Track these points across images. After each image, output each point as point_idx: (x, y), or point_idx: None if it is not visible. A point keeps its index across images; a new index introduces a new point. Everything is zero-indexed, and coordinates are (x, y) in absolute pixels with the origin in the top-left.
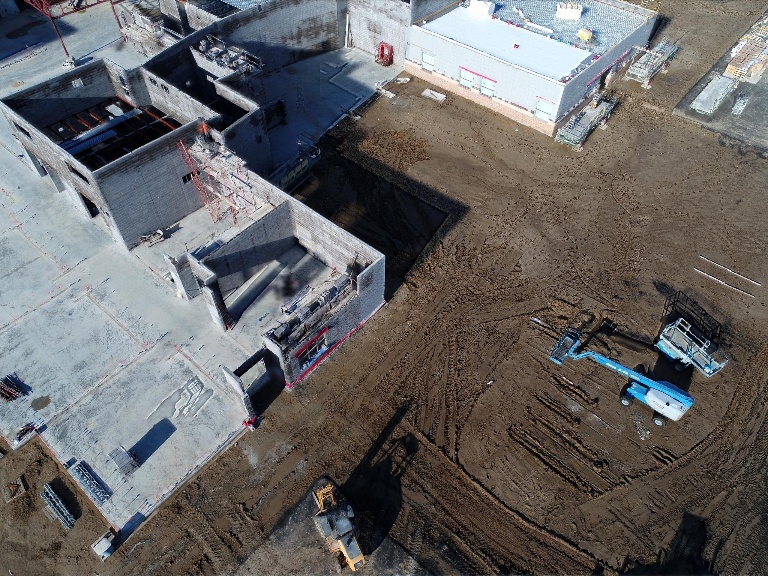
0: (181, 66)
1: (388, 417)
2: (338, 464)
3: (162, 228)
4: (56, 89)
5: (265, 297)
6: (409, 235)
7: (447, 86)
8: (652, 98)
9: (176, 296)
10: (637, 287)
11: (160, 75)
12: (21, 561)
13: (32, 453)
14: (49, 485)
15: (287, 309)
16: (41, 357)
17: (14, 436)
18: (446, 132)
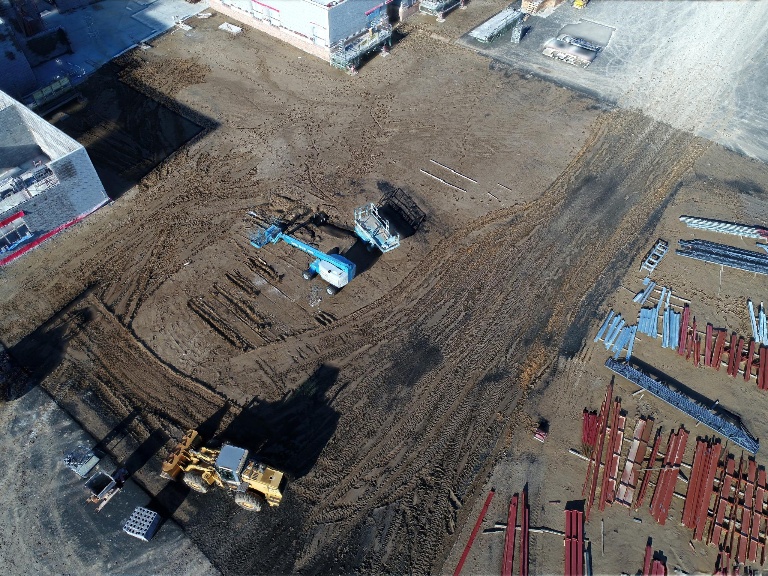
0: None
1: (78, 293)
2: (14, 331)
3: None
4: None
5: None
6: (159, 145)
7: (245, 20)
8: (442, 30)
9: None
10: (361, 186)
11: None
12: None
13: None
14: None
15: None
16: None
17: None
18: (230, 59)
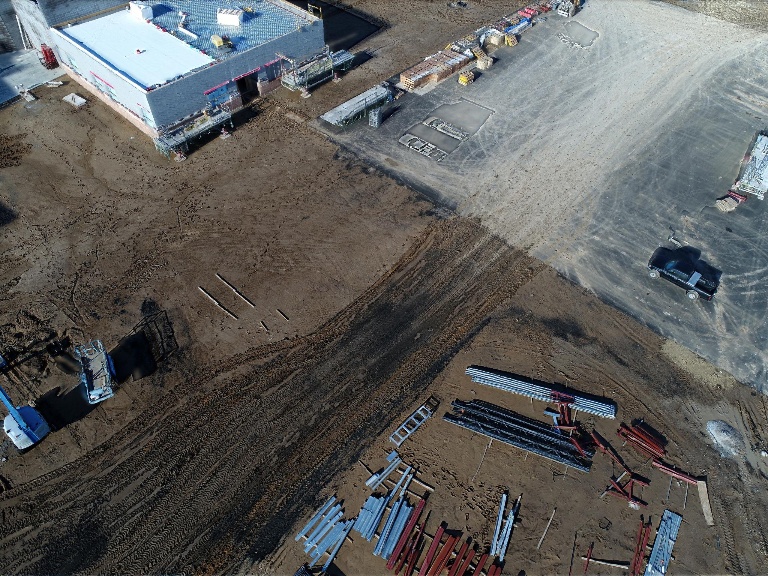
0: None
1: None
2: None
3: None
4: None
5: None
6: None
7: (93, 91)
8: (301, 108)
9: None
10: (123, 305)
11: None
12: None
13: None
14: None
15: None
16: None
17: None
18: (58, 138)
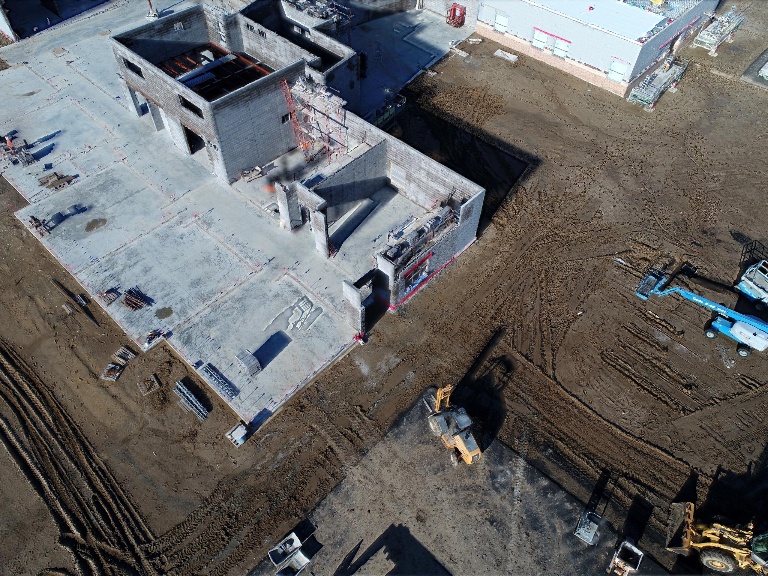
0: (271, 16)
1: (487, 339)
2: (444, 376)
3: (259, 166)
4: (160, 31)
5: (362, 230)
6: (493, 181)
7: (519, 47)
8: (719, 65)
9: (278, 226)
10: (714, 235)
11: None
12: (163, 445)
13: (161, 355)
14: (181, 382)
15: (395, 235)
16: (159, 274)
17: (144, 340)
18: (520, 90)
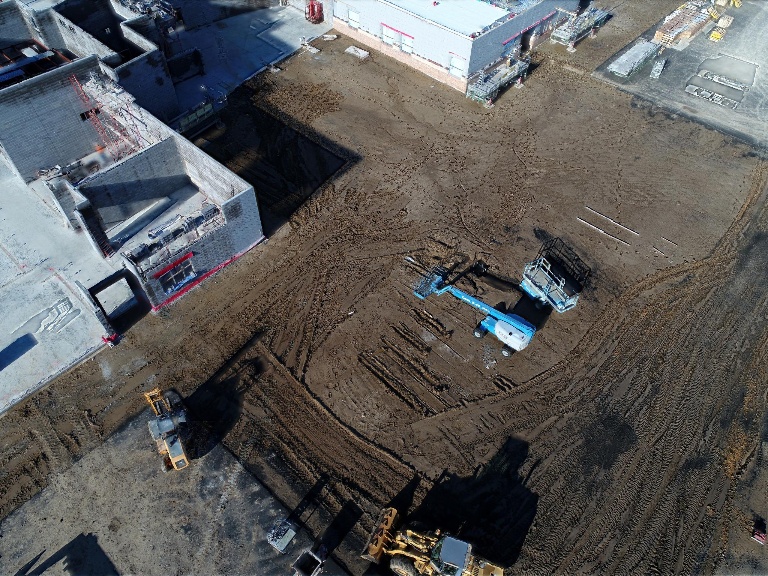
0: (98, 12)
1: (245, 340)
2: (187, 379)
3: (62, 164)
4: None
5: (149, 229)
6: (303, 179)
7: (372, 43)
8: (574, 61)
9: (63, 226)
10: (517, 233)
11: (74, 19)
12: None
13: None
14: None
15: (152, 234)
16: None
17: None
18: (362, 86)
